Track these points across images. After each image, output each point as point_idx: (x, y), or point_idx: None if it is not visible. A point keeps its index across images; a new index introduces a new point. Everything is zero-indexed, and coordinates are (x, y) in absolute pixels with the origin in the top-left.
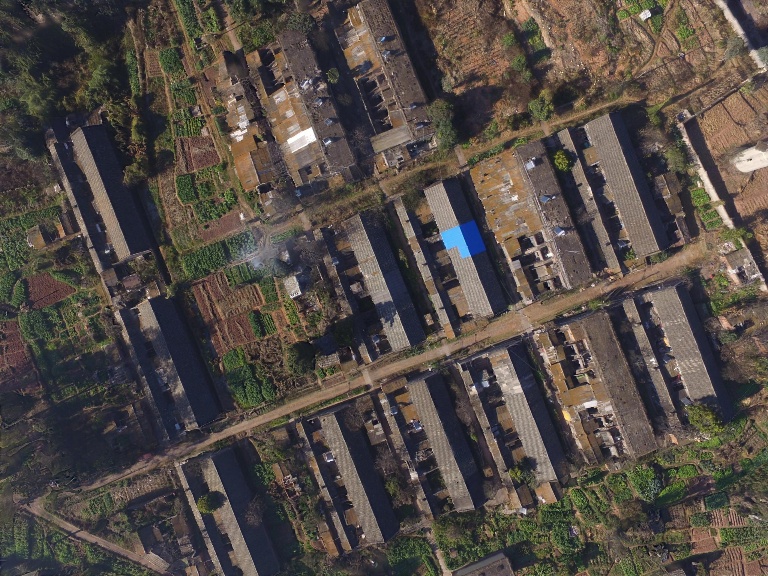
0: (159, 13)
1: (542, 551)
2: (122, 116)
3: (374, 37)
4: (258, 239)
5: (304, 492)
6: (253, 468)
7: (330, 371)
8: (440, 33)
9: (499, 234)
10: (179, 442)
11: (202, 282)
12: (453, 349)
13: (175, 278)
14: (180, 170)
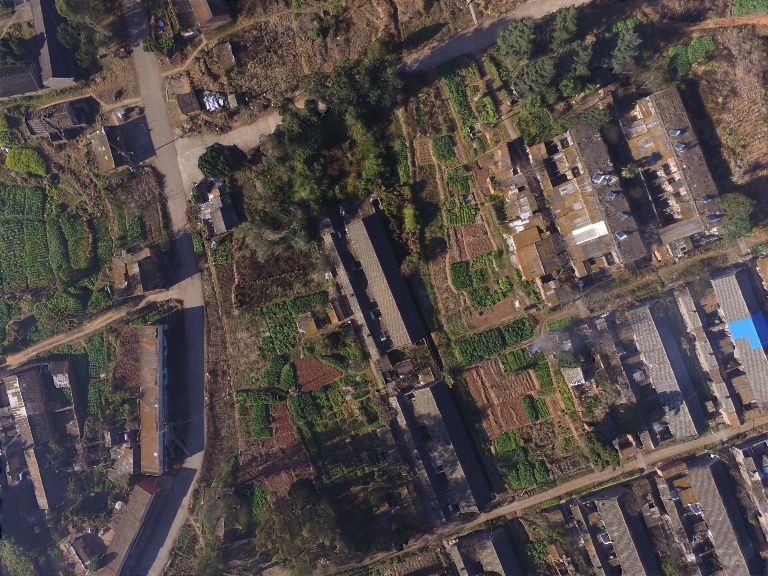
0: (430, 101)
1: None
2: (396, 205)
3: (666, 130)
4: (534, 326)
5: (577, 572)
6: (524, 547)
7: None
8: (725, 122)
9: None
10: None
11: (475, 368)
12: (730, 434)
13: (447, 363)
14: (454, 258)
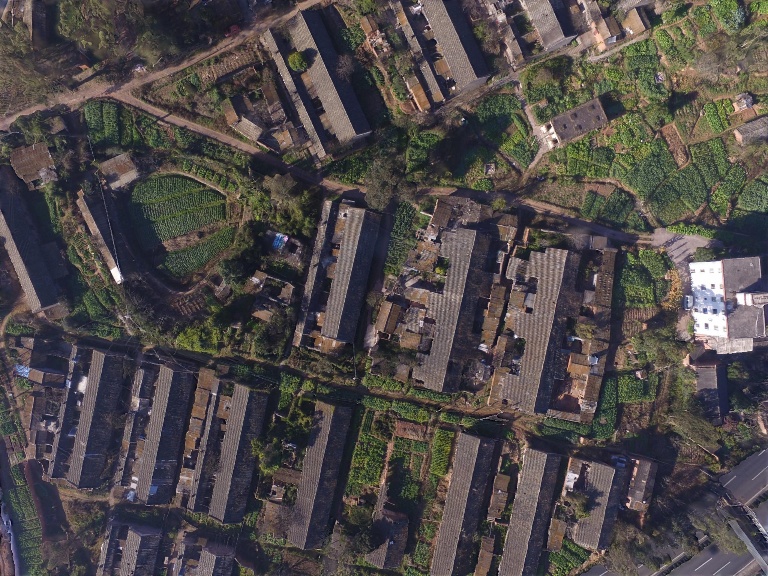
0: None
1: (629, 101)
2: None
3: None
4: None
5: (393, 48)
6: (340, 33)
7: None
8: None
9: None
10: (264, 16)
11: None
12: None
13: None
14: None
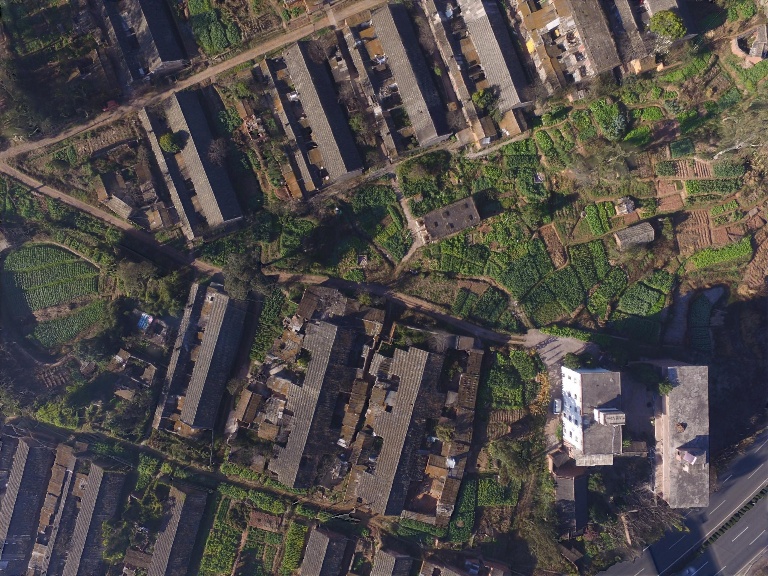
0: None
1: (507, 199)
2: None
3: None
4: None
5: (268, 134)
6: (217, 115)
7: (295, 12)
8: None
9: None
10: (143, 92)
11: None
12: None
13: None
14: None
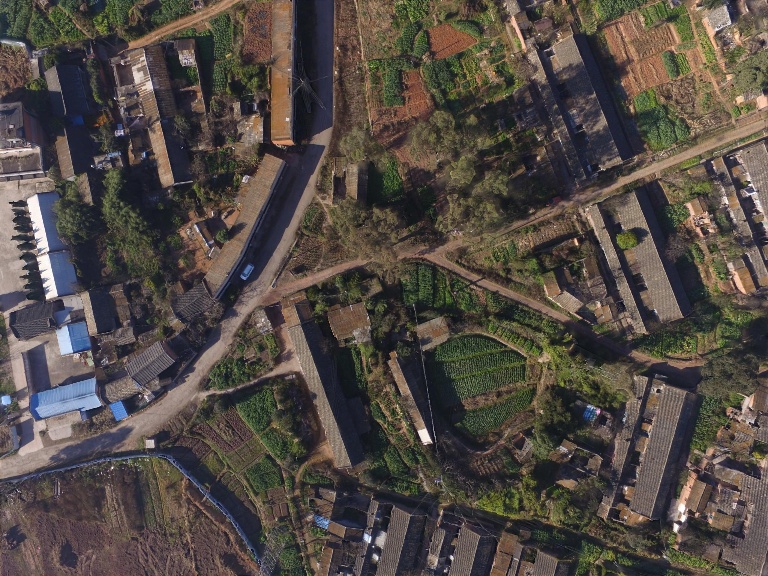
0: None
1: None
2: None
3: None
4: None
5: (720, 229)
6: (663, 210)
7: (746, 108)
8: None
9: None
10: (585, 187)
11: (615, 23)
12: None
13: (586, 21)
14: None
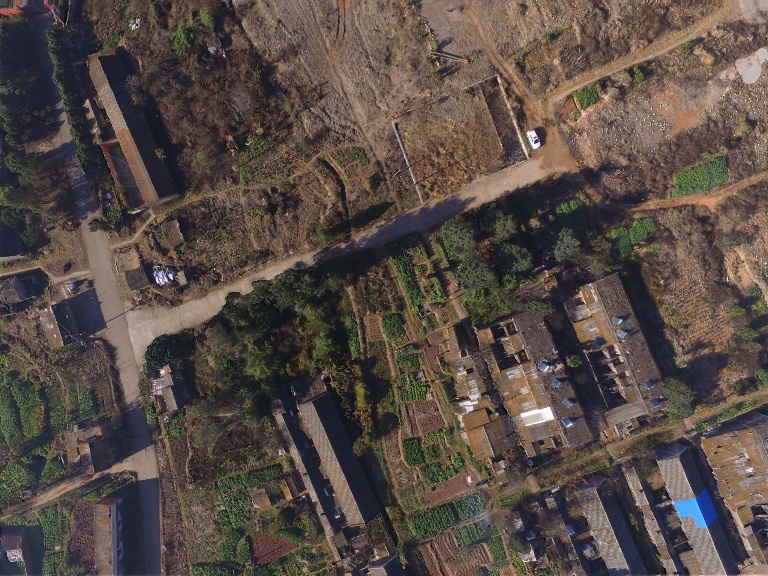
0: (379, 279)
1: None
2: None
3: (609, 317)
4: (486, 502)
5: None
6: None
7: None
8: (667, 303)
9: (732, 502)
10: None
11: (430, 542)
12: None
13: (402, 537)
14: (405, 434)
